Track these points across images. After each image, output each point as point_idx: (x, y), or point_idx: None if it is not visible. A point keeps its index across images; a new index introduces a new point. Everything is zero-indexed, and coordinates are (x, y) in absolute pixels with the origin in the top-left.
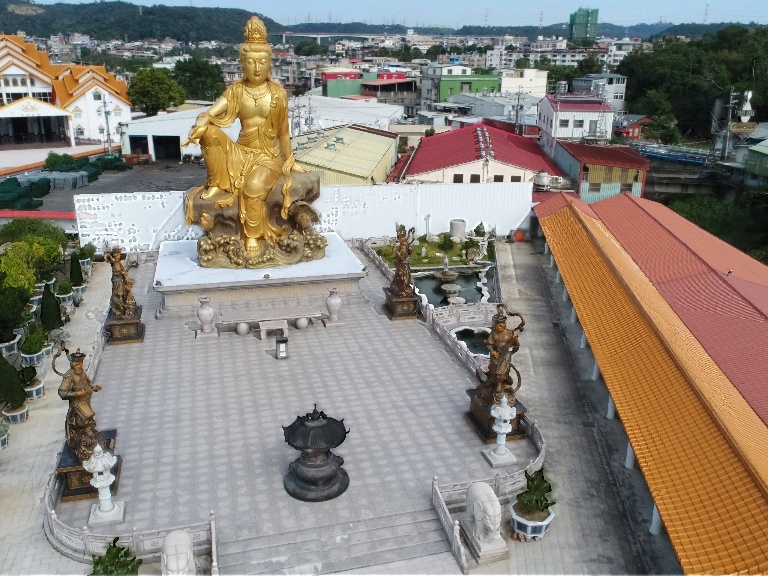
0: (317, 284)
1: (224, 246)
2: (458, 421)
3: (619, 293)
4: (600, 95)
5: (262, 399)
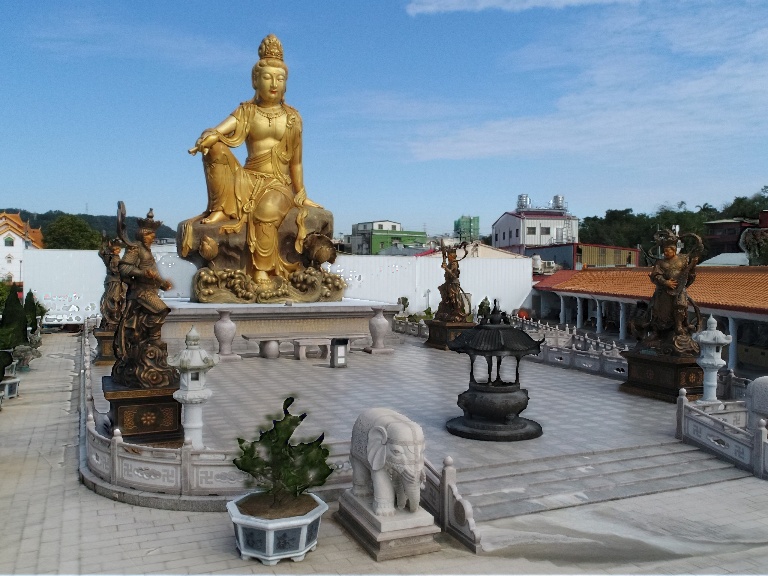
0: (345, 319)
1: (227, 281)
2: (616, 393)
3: (733, 276)
4: (561, 207)
5: (343, 387)
